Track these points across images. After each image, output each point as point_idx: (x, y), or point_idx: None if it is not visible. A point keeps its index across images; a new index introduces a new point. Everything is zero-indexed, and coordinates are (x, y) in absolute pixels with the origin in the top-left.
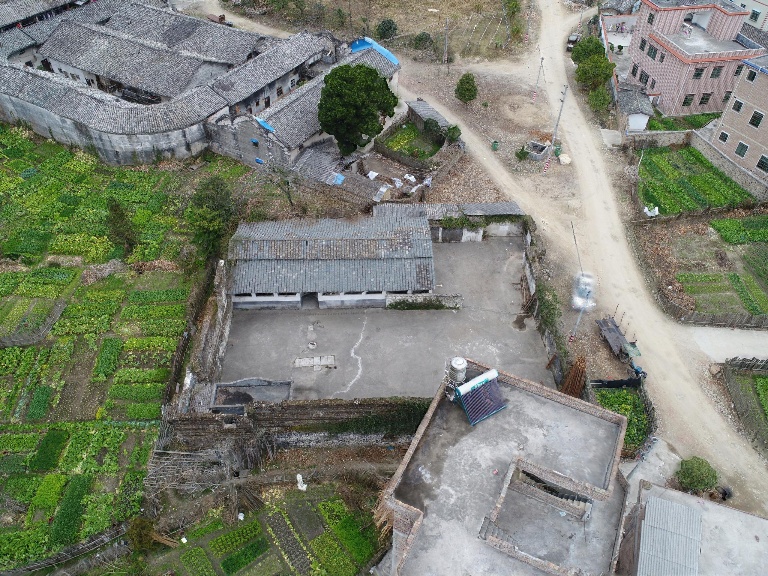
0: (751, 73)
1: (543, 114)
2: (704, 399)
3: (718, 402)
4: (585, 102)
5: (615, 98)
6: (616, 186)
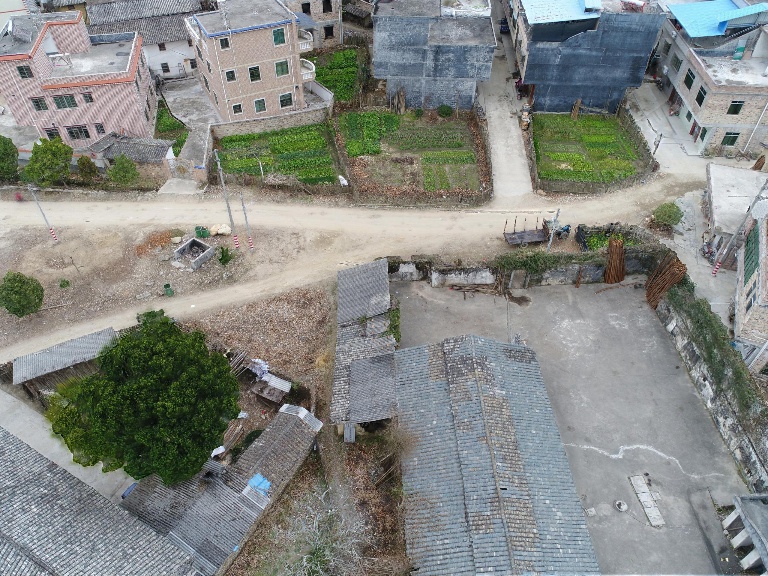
0: (222, 42)
1: (94, 236)
2: (574, 205)
3: (575, 199)
4: (85, 194)
5: (98, 166)
6: (282, 201)
